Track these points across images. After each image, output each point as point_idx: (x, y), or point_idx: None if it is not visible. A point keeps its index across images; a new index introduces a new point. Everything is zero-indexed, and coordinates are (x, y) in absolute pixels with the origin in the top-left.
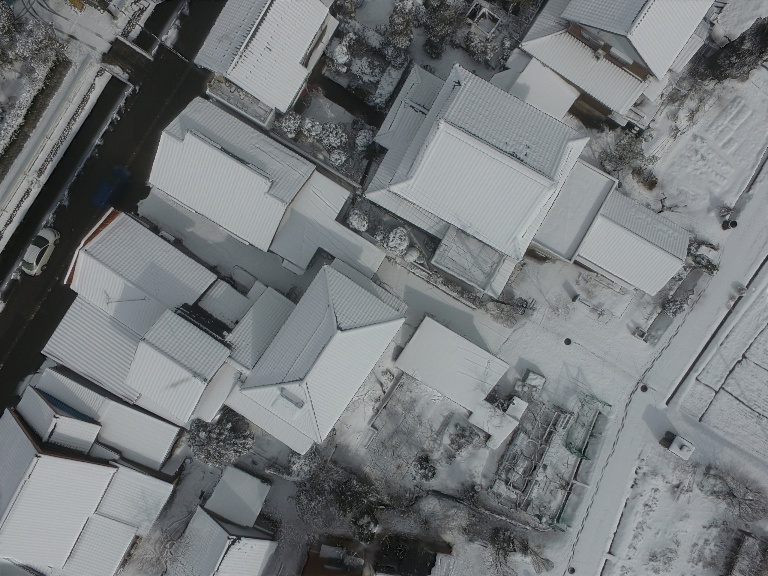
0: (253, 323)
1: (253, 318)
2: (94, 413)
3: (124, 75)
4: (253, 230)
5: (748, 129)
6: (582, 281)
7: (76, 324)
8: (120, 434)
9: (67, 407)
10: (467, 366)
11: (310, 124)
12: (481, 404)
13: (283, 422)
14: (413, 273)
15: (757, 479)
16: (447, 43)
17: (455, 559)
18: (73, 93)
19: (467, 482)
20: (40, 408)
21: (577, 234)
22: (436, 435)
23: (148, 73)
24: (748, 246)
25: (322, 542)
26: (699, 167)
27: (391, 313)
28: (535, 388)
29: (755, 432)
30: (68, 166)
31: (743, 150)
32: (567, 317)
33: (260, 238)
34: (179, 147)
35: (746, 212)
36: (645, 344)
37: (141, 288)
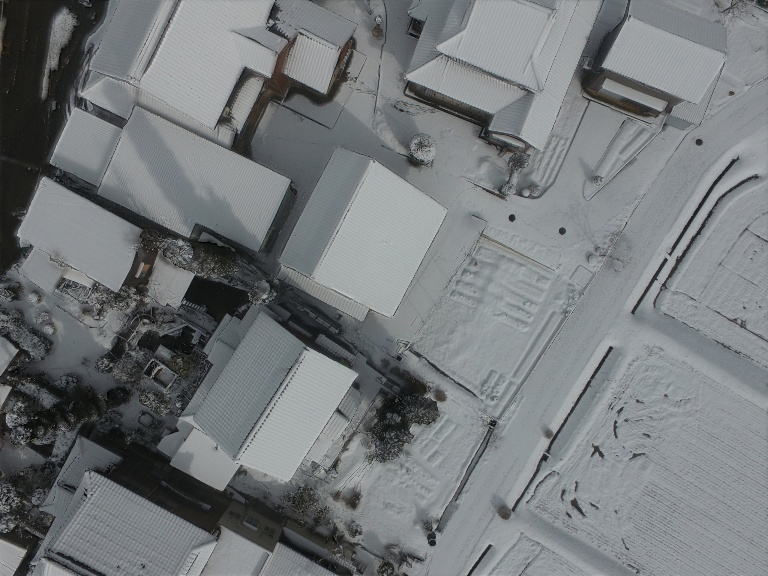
0: None
1: None
2: None
3: None
4: None
5: (452, 442)
6: None
7: None
8: None
9: None
10: None
11: None
12: None
13: None
14: None
15: None
16: (134, 388)
17: None
18: None
19: None
20: None
21: None
22: None
23: None
24: (455, 555)
25: None
26: (405, 480)
27: None
28: None
29: None
30: None
31: (448, 463)
32: None
33: None
34: None
35: (453, 522)
36: None
37: None
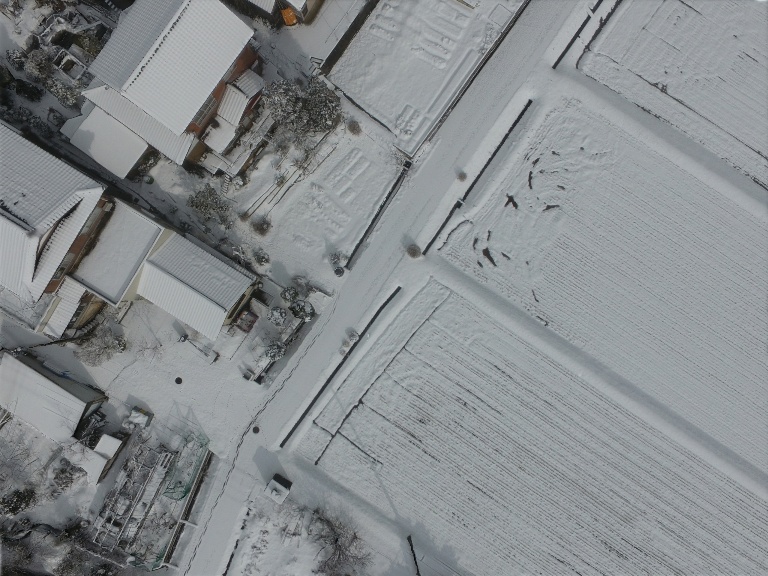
0: None
1: None
2: None
3: None
4: None
5: (366, 180)
6: None
7: None
8: None
9: None
10: (50, 402)
11: None
12: (70, 441)
13: None
14: None
15: (366, 525)
16: None
17: None
18: None
19: (75, 517)
20: None
21: (127, 279)
22: (44, 469)
23: None
24: (363, 293)
25: None
26: (316, 214)
27: None
28: None
29: (369, 477)
30: None
31: (360, 200)
32: (178, 356)
33: None
34: None
35: (362, 260)
36: (258, 386)
37: None
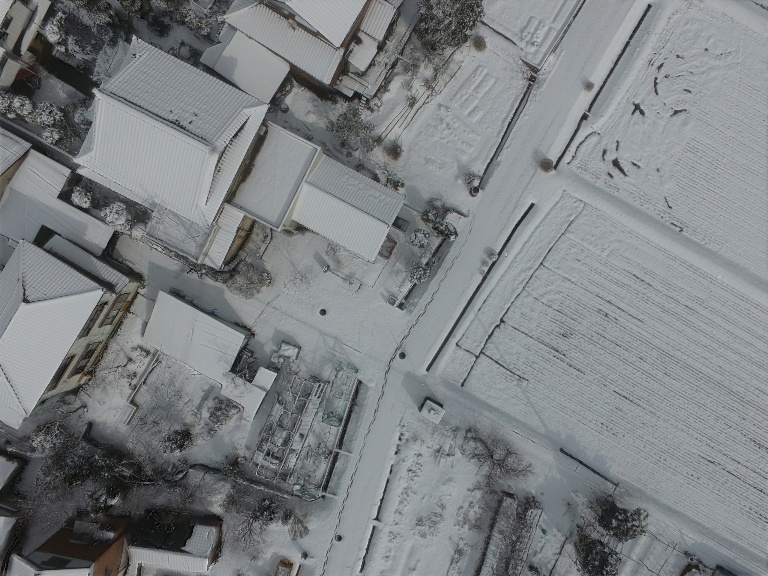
0: None
1: None
2: None
3: None
4: None
5: (492, 97)
6: (331, 252)
7: None
8: None
9: None
10: (207, 338)
11: (18, 103)
12: (227, 376)
13: None
14: (156, 249)
15: (517, 441)
16: (173, 21)
17: (214, 530)
18: None
19: (231, 455)
20: None
21: (285, 202)
22: (197, 409)
23: None
24: (498, 212)
25: (77, 518)
26: (446, 136)
27: (88, 285)
28: None
29: (516, 395)
30: None
31: (488, 118)
32: (321, 288)
33: None
34: None
35: (495, 179)
36: (401, 312)
37: None
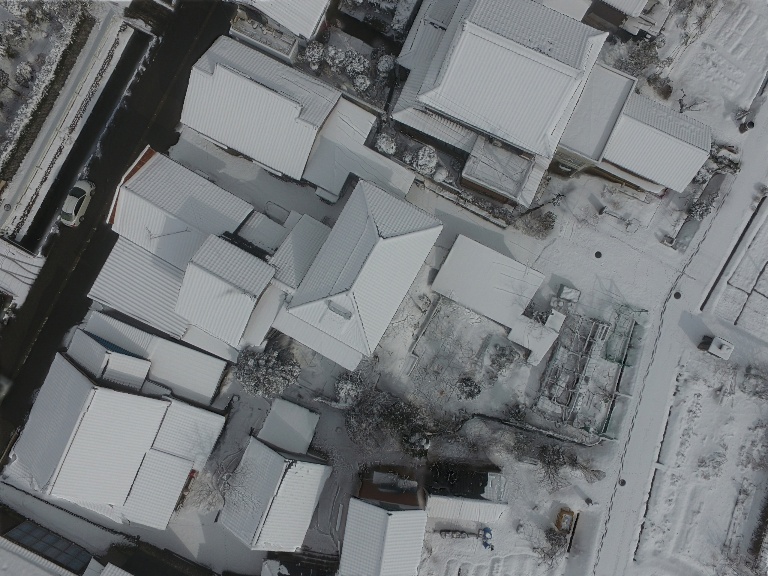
0: (293, 247)
1: (293, 242)
2: (143, 351)
3: (146, 27)
4: (285, 159)
5: (755, 34)
6: (607, 193)
7: (119, 266)
8: (170, 371)
9: (116, 347)
10: (503, 281)
11: (333, 51)
12: (520, 319)
13: (331, 339)
14: (442, 196)
15: None
16: None
17: (507, 477)
18: (99, 48)
19: (511, 402)
20: (91, 347)
21: (602, 135)
22: (477, 358)
23: (169, 23)
24: (766, 147)
25: (374, 469)
26: (711, 74)
27: (429, 221)
28: (570, 303)
29: None
30: (97, 122)
31: (752, 54)
32: (595, 231)
33: (293, 166)
34: (209, 81)
35: (761, 114)
36: (674, 252)
37: (182, 219)
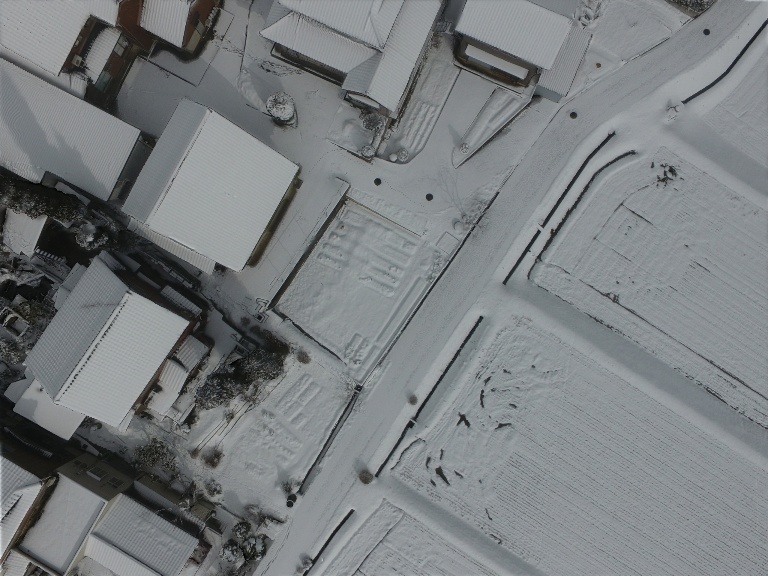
0: None
1: None
2: None
3: None
4: None
5: (317, 405)
6: None
7: None
8: None
9: None
10: None
11: None
12: None
13: None
14: None
15: None
16: None
17: None
18: None
19: None
20: None
21: (72, 550)
22: None
23: None
24: (316, 518)
25: None
26: (268, 441)
27: None
28: None
29: None
30: None
31: (311, 425)
32: None
33: None
34: None
35: (315, 485)
36: None
37: None
